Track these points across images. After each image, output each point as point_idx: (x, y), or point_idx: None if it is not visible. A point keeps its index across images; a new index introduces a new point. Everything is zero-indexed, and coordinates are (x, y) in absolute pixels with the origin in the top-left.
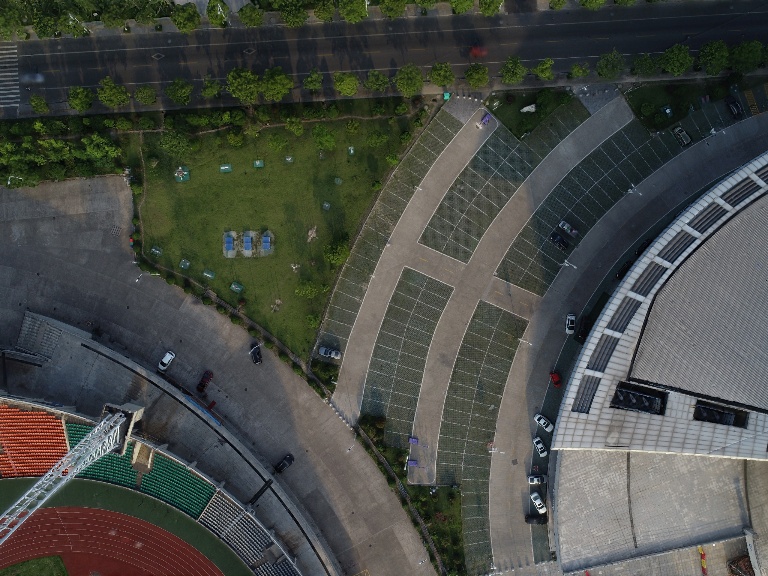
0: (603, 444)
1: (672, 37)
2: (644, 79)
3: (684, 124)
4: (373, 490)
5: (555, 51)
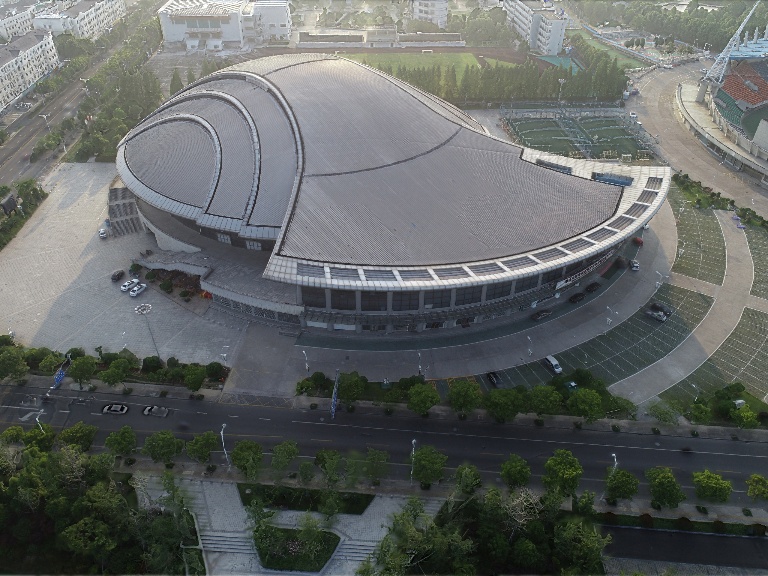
0: (633, 167)
1: (574, 457)
2: (602, 420)
3: (549, 377)
4: (759, 211)
5: (723, 461)
